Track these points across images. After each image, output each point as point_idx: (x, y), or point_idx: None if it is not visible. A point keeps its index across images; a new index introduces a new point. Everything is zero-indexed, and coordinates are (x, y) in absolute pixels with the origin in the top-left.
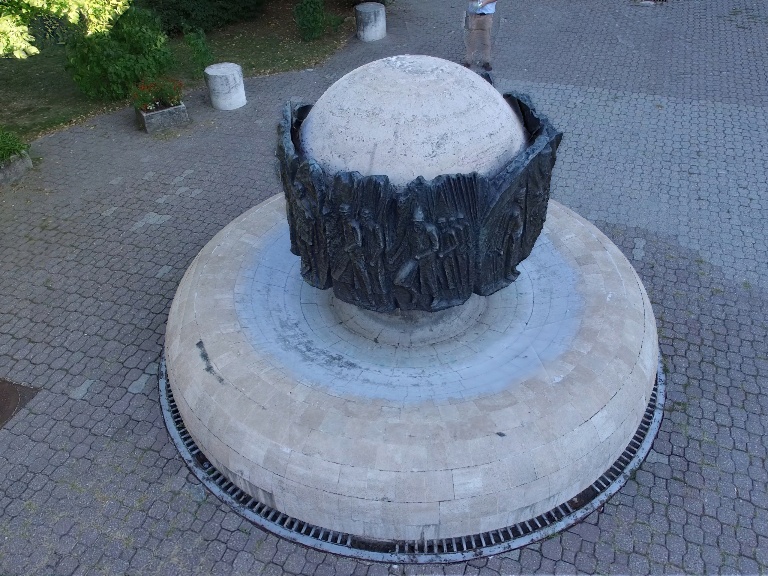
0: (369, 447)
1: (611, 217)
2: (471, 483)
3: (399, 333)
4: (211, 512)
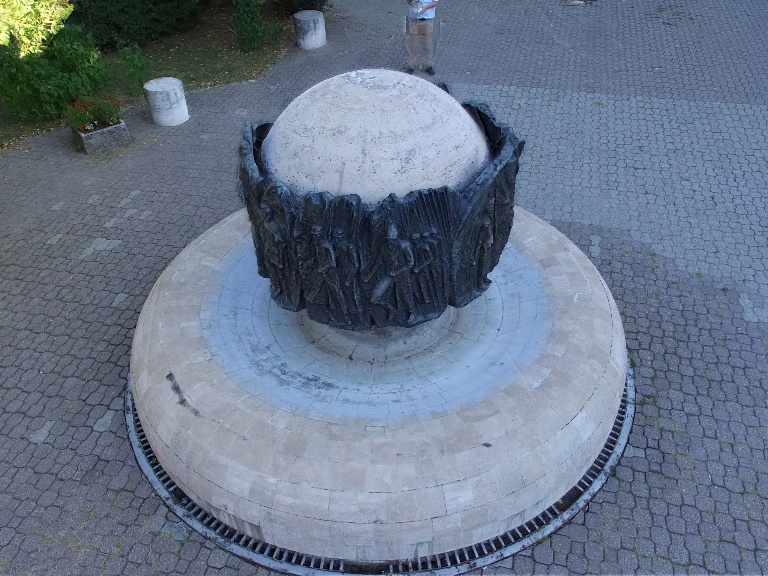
0: (357, 470)
1: (565, 216)
2: (462, 497)
3: (373, 348)
4: (195, 550)
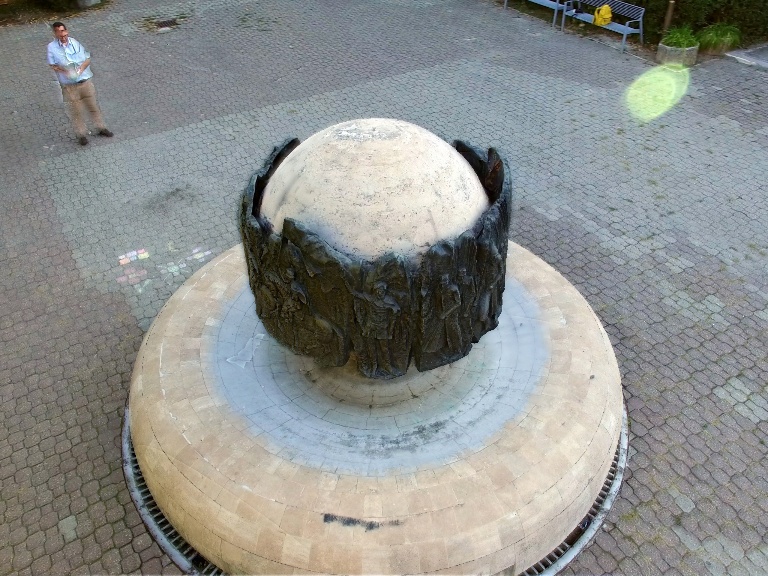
0: (556, 455)
1: None
2: (612, 421)
3: (422, 377)
4: None
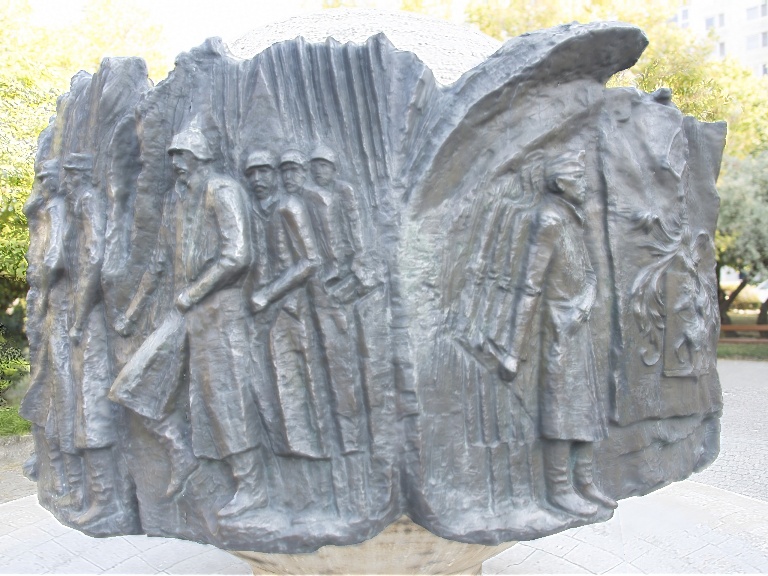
0: None
1: None
2: None
3: None
4: None
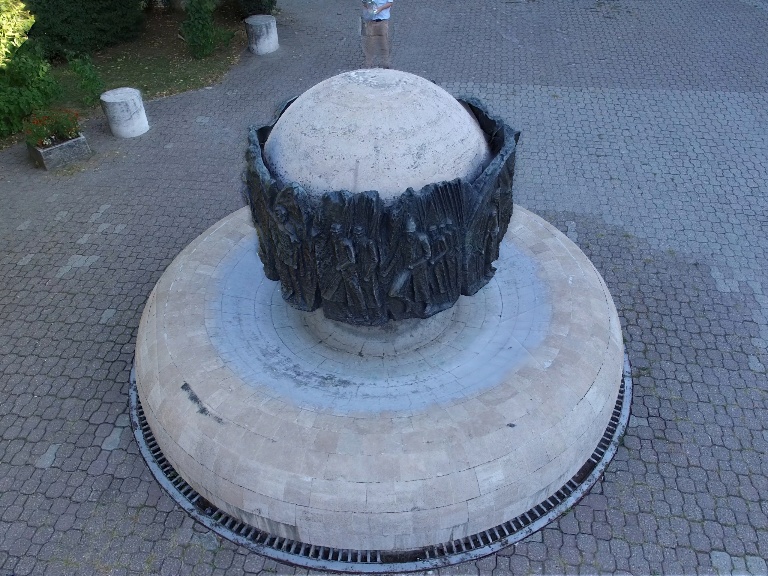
0: (391, 461)
1: (540, 204)
2: (494, 477)
3: (382, 343)
4: (229, 558)
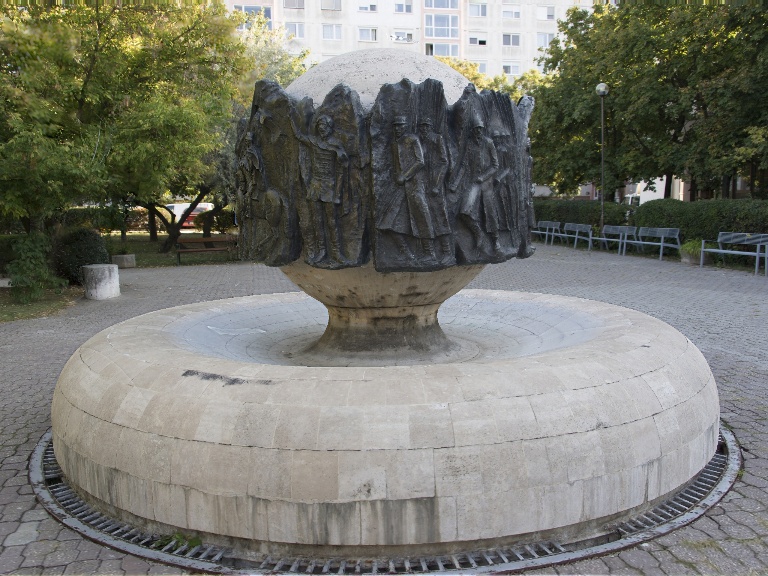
0: (541, 373)
1: None
2: (665, 388)
3: (417, 361)
4: None
